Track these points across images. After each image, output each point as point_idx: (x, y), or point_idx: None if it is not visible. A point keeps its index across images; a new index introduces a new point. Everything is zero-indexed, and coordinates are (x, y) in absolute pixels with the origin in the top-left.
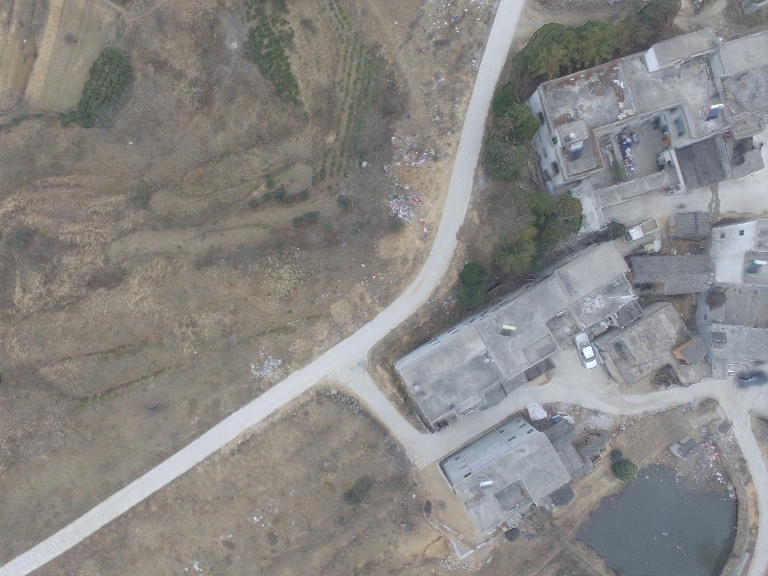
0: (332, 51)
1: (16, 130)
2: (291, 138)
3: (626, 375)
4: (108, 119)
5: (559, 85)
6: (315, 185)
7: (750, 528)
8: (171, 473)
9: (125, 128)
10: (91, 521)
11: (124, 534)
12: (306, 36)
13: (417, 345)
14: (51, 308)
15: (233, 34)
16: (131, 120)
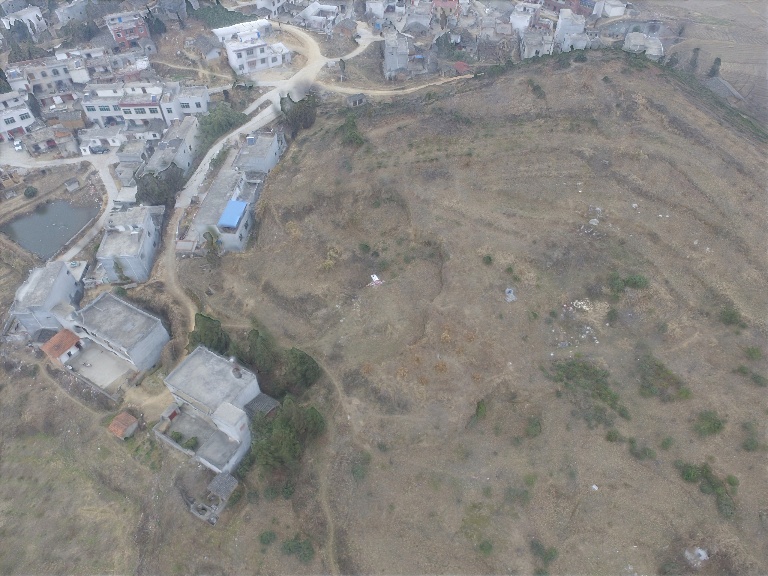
0: None
1: None
2: None
3: (27, 143)
4: None
5: (19, 66)
6: None
7: (100, 210)
8: None
9: None
10: None
11: None
12: None
13: None
14: None
15: None
16: None
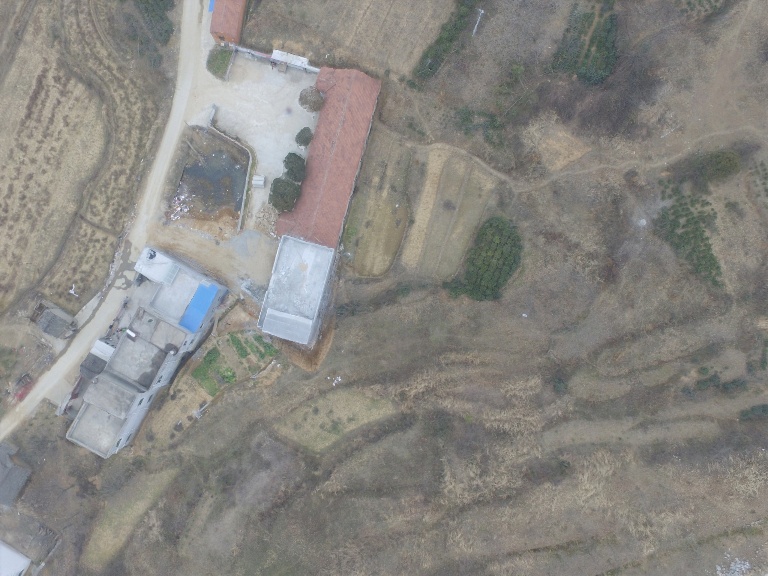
0: (762, 235)
1: (405, 302)
2: (711, 319)
3: None
4: (498, 290)
5: None
6: (751, 372)
7: None
8: None
9: (515, 299)
10: None
11: None
12: (732, 219)
13: None
14: (491, 501)
15: (641, 210)
16: (520, 290)
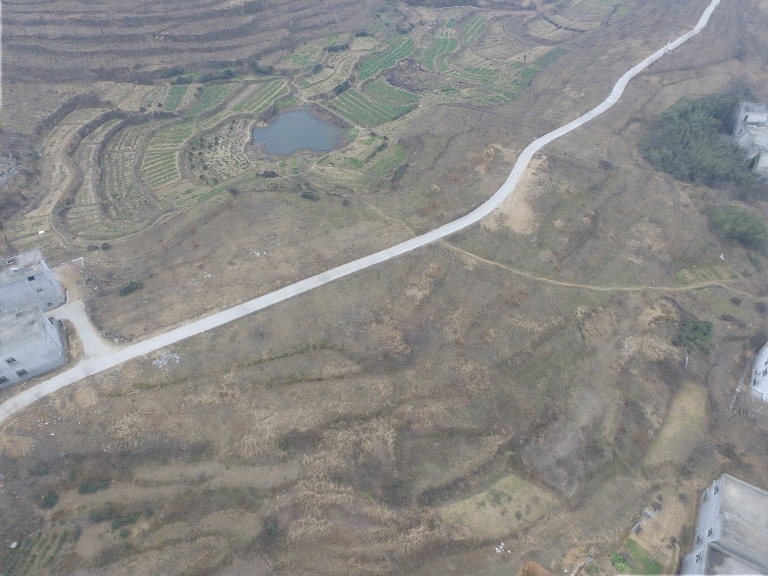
0: None
1: None
2: None
3: None
4: None
5: None
6: (79, 530)
7: None
8: (262, 300)
9: None
10: (327, 277)
11: (303, 269)
12: None
13: (41, 376)
14: (353, 419)
15: None
16: None
